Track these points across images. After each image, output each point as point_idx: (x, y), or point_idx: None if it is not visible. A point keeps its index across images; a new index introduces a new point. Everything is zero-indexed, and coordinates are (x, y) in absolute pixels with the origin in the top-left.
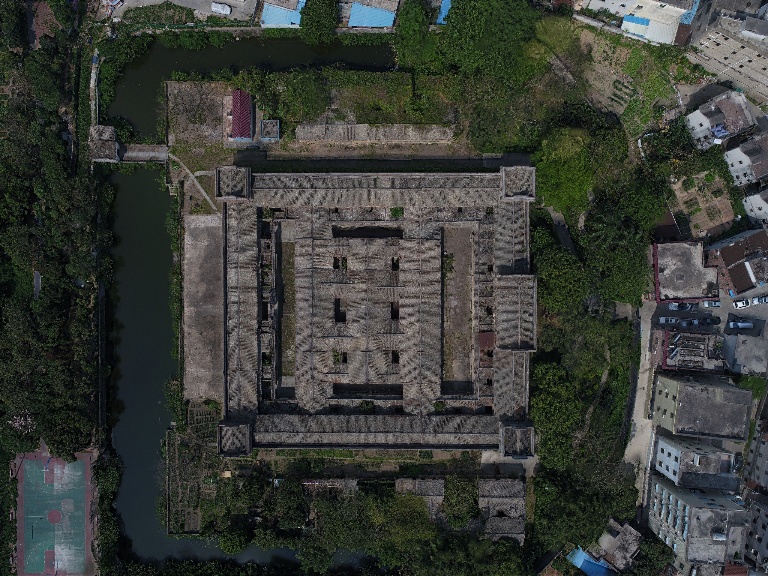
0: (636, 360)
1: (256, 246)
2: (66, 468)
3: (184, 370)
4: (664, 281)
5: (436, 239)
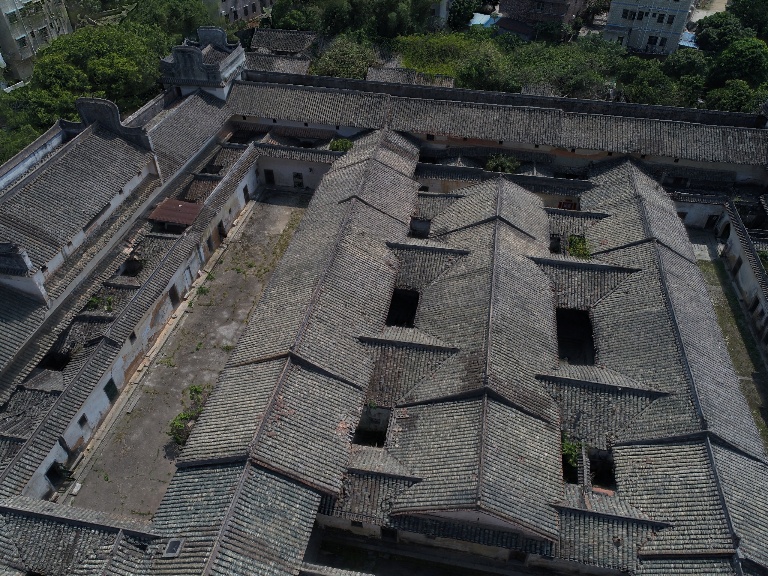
0: None
1: None
2: None
3: None
4: None
5: (191, 470)
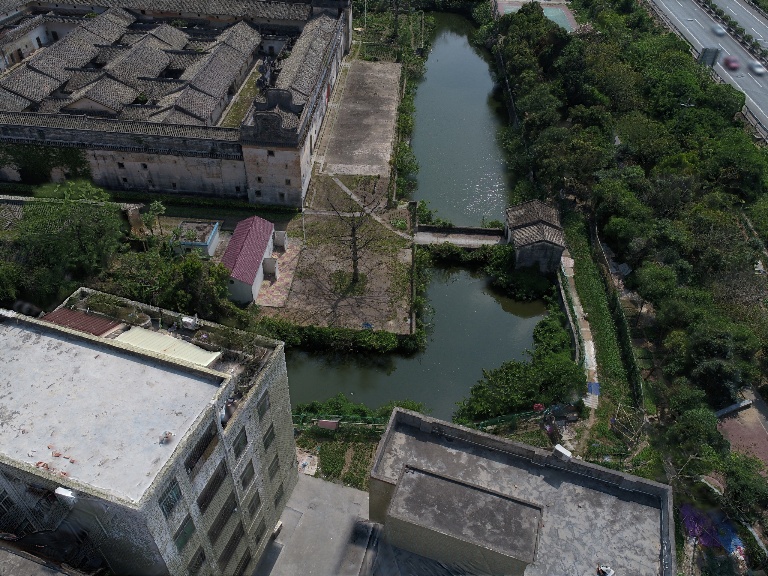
0: None
1: None
2: None
3: None
4: None
5: None
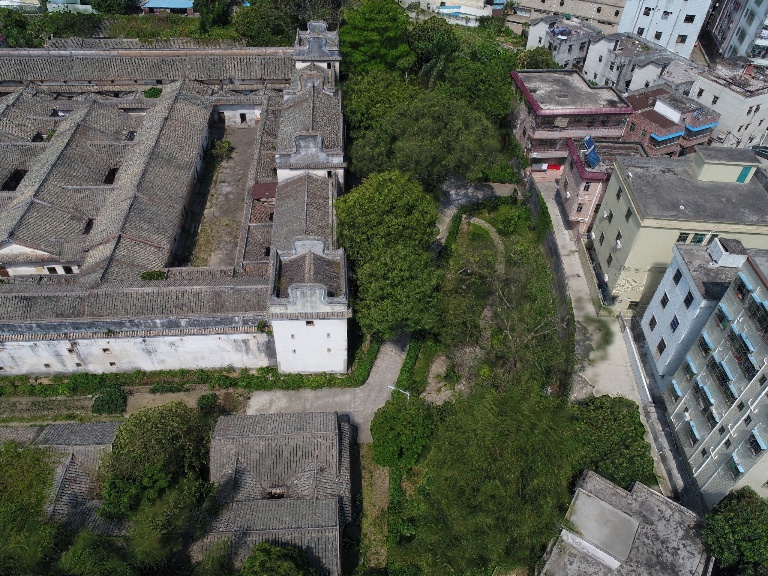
0: (544, 224)
1: None
2: None
3: None
4: (540, 99)
5: None
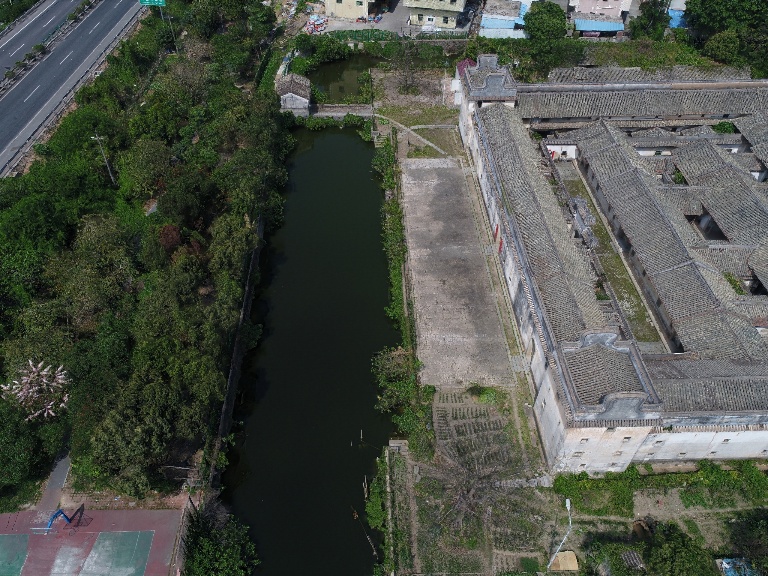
0: None
1: (534, 148)
2: (92, 556)
3: (416, 336)
4: None
5: None
